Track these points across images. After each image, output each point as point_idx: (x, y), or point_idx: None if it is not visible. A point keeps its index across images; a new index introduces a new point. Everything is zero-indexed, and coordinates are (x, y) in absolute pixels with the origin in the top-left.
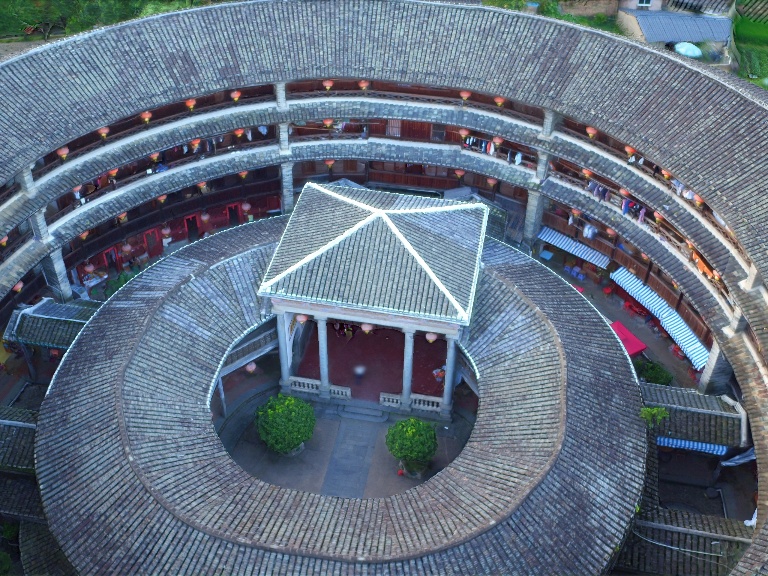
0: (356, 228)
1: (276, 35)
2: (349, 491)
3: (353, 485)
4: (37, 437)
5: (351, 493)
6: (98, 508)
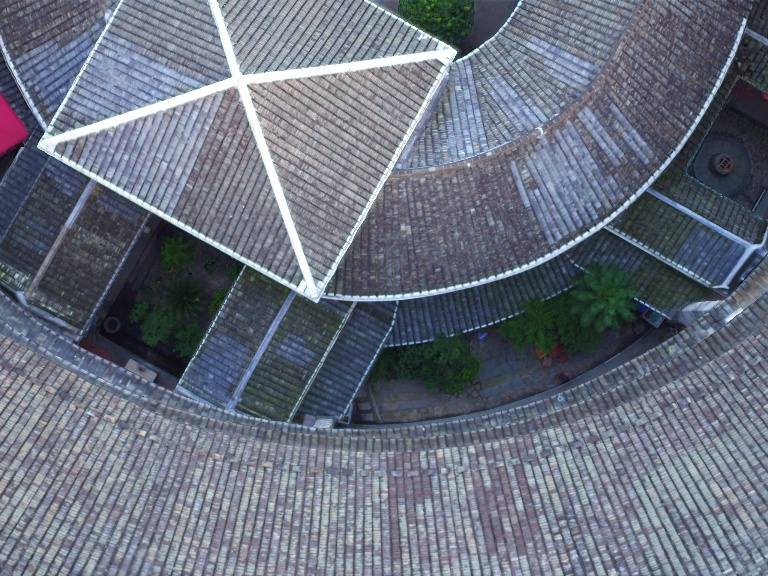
0: (287, 72)
1: (292, 567)
2: None
3: None
4: None
5: None
6: None
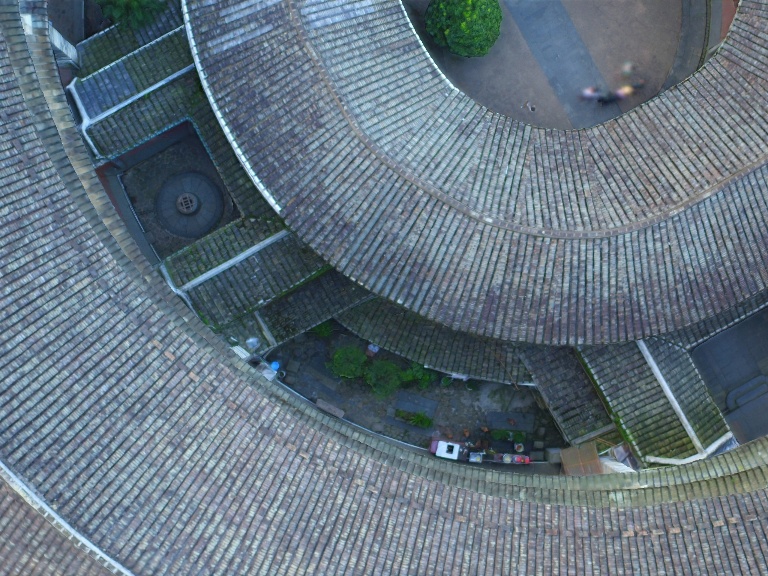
0: None
1: None
2: (558, 33)
3: (556, 23)
4: (331, 261)
5: (562, 33)
6: (492, 283)
